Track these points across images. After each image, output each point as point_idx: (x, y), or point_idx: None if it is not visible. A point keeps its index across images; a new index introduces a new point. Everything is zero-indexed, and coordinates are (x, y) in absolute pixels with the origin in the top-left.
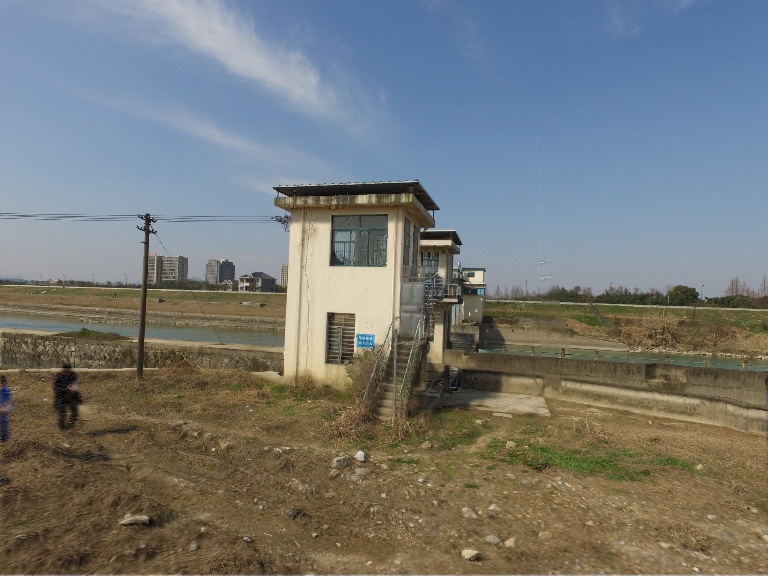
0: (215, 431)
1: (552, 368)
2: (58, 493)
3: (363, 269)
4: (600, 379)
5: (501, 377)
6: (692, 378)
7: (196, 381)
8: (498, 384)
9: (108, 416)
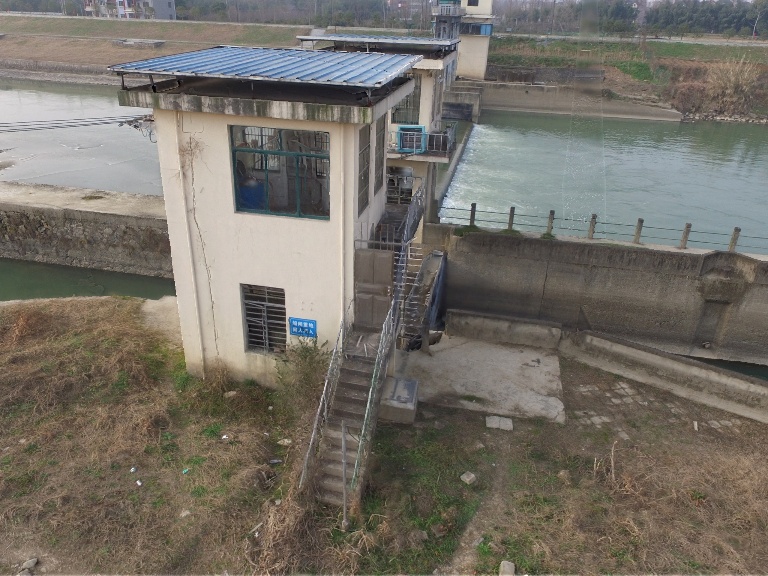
0: None
1: (575, 257)
2: None
3: (292, 223)
4: (639, 274)
5: (503, 324)
6: (763, 277)
7: (54, 388)
8: (498, 332)
9: None
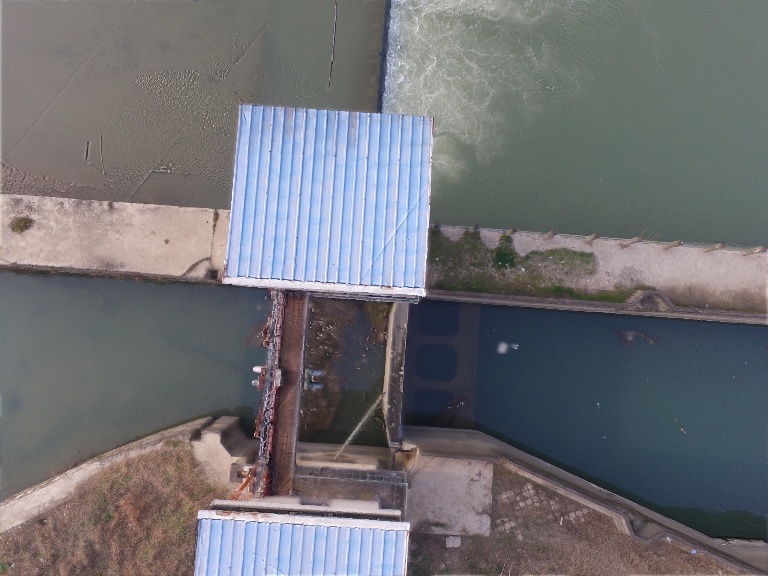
0: None
1: None
2: None
3: None
4: None
5: None
6: None
7: None
8: None
9: None
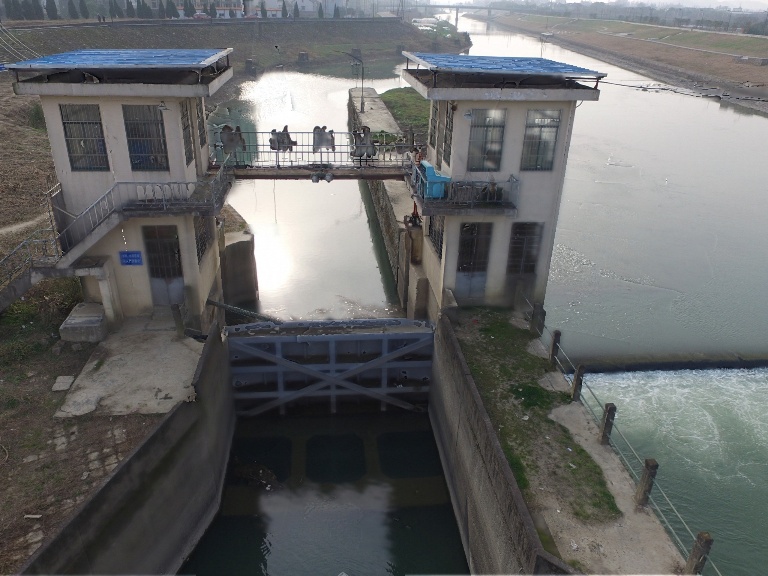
0: None
1: (472, 416)
2: None
3: None
4: (495, 502)
5: None
6: None
7: None
8: None
9: None
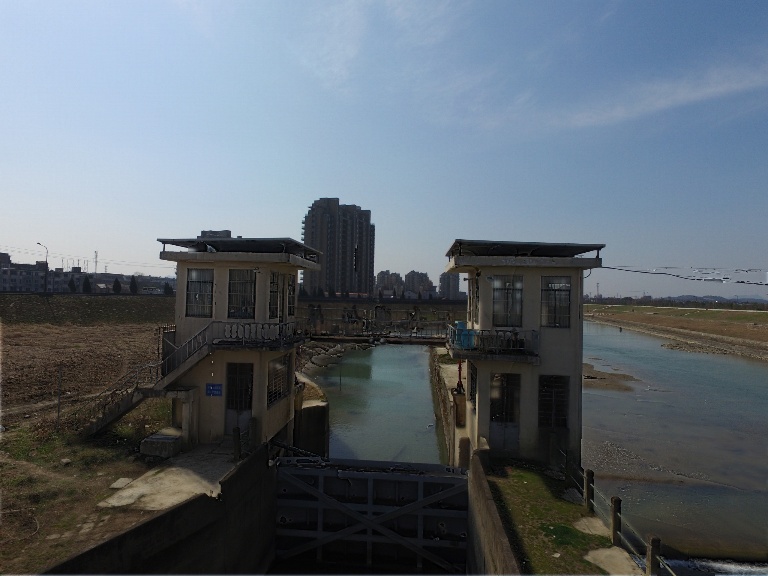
0: None
1: (493, 544)
2: (2, 399)
3: None
4: None
5: None
6: None
7: None
8: None
9: None
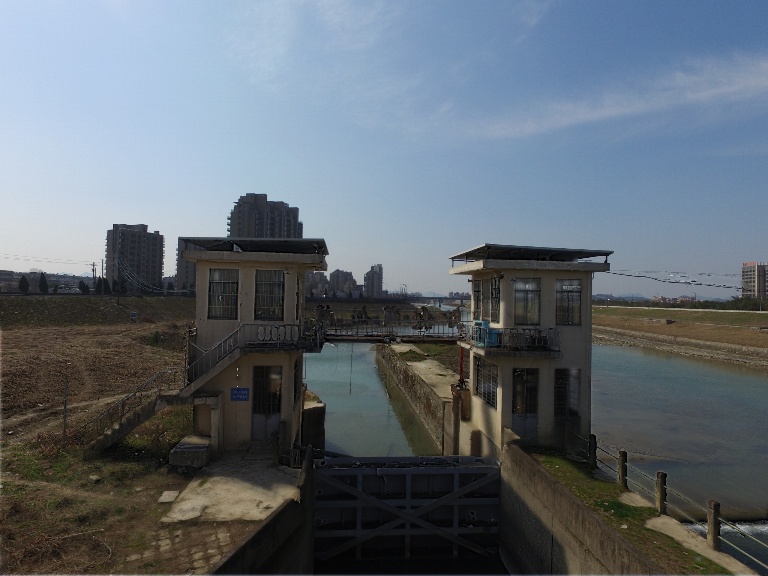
0: (66, 418)
1: (572, 522)
2: None
3: None
4: None
5: None
6: None
7: None
8: None
9: (108, 400)
